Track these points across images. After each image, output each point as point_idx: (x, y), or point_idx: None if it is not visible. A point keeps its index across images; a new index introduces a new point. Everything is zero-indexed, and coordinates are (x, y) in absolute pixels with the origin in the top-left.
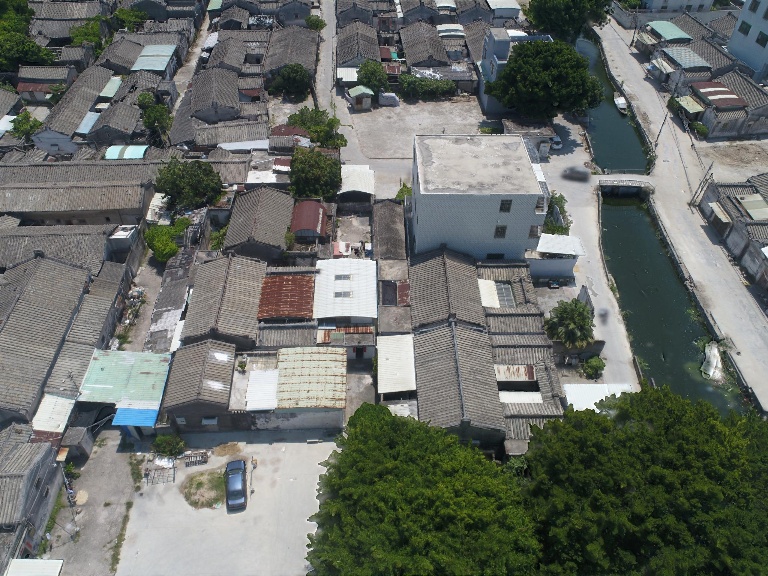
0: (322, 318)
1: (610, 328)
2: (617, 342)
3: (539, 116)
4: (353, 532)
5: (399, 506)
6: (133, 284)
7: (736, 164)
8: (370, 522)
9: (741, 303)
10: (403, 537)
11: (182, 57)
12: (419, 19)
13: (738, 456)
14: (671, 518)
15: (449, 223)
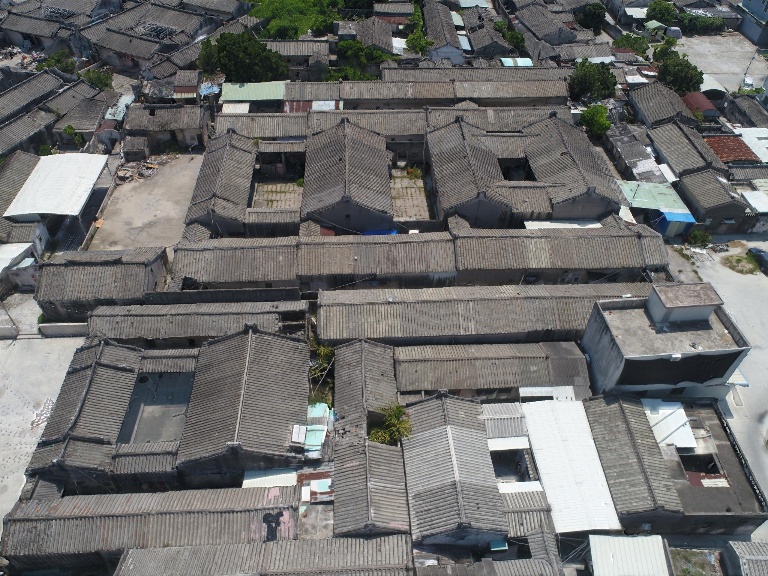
0: (767, 162)
1: None
2: None
3: None
4: None
5: None
6: None
7: None
8: None
9: None
10: None
11: None
12: None
13: None
14: None
15: None
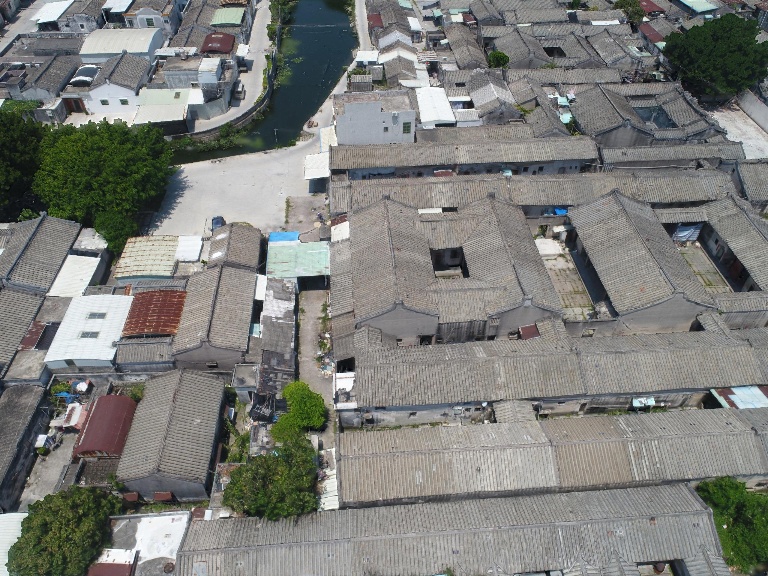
0: None
1: None
2: None
3: None
4: None
5: None
6: None
7: None
8: None
9: None
10: None
11: None
12: None
13: None
14: None
15: None
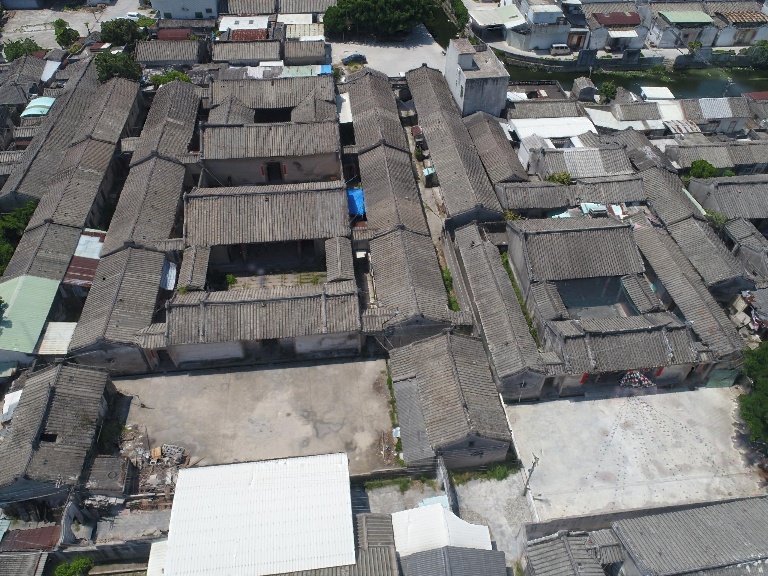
0: None
1: None
2: None
3: None
4: None
5: None
6: None
7: None
8: None
9: None
10: None
11: None
12: None
13: None
14: None
15: None
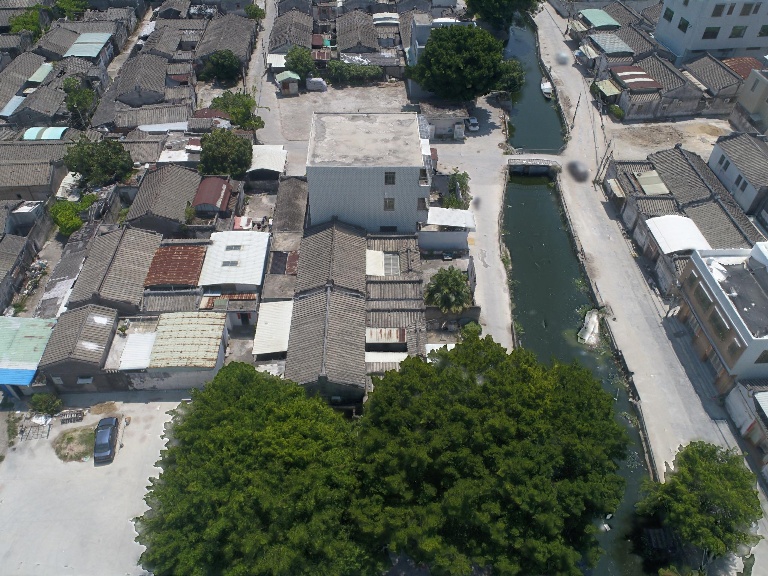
0: (207, 285)
1: (495, 296)
2: (499, 309)
3: (456, 99)
4: (184, 472)
5: (226, 447)
6: (37, 257)
7: (647, 144)
8: (201, 463)
9: (626, 273)
10: (228, 475)
11: (119, 45)
12: (355, 8)
13: (543, 397)
14: (465, 451)
15: (338, 196)
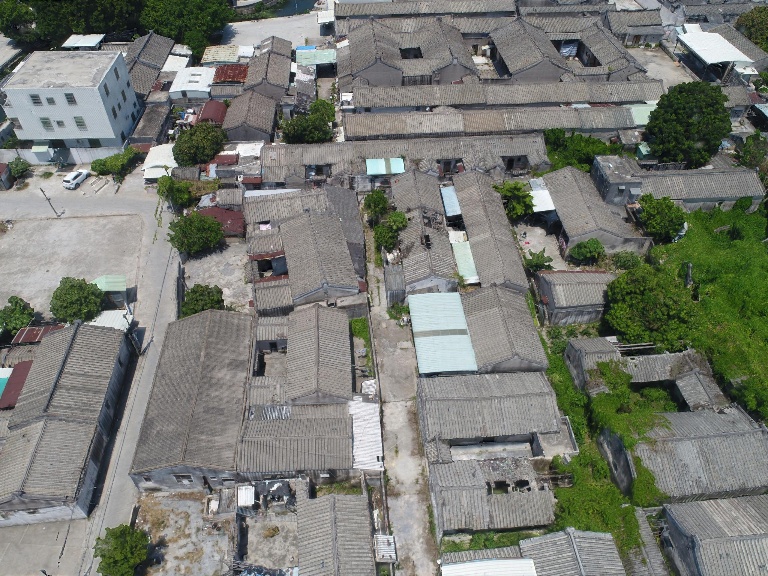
0: None
1: None
2: None
3: None
4: None
5: None
6: None
7: None
8: None
9: None
10: None
11: None
12: None
13: None
14: None
15: None
